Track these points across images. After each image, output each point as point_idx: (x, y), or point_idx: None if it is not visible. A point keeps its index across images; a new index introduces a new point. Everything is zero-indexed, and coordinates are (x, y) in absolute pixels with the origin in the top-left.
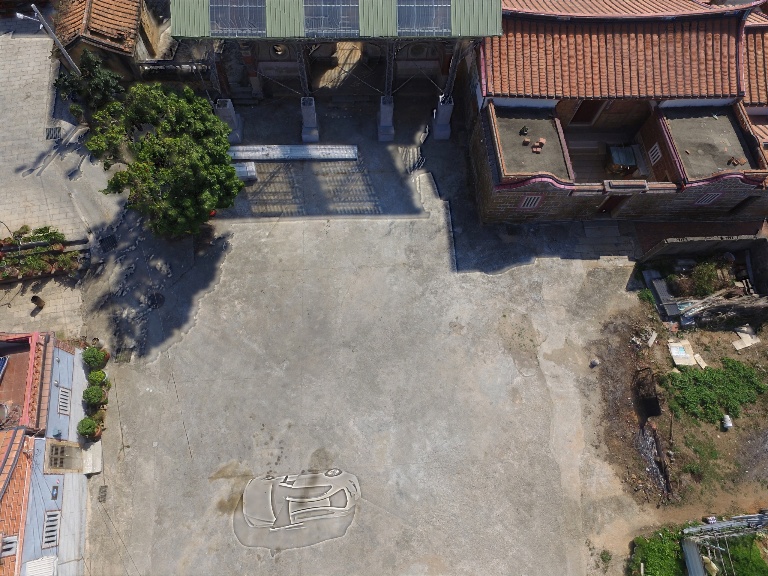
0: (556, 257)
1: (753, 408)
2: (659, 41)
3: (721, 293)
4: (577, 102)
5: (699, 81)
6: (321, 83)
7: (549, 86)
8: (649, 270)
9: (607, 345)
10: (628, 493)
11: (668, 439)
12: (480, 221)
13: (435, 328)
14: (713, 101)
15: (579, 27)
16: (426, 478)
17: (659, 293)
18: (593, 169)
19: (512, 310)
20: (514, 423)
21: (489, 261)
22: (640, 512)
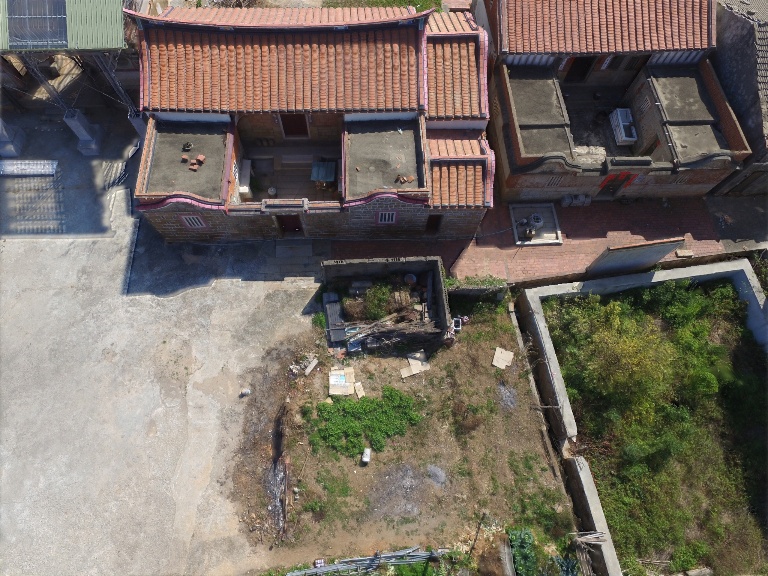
0: (237, 279)
1: (401, 441)
2: (335, 52)
3: (391, 318)
4: (272, 115)
5: (376, 94)
6: (36, 94)
7: (213, 100)
8: (329, 292)
9: (264, 373)
10: (243, 534)
11: (297, 475)
12: (165, 240)
13: (86, 355)
14: (397, 115)
15: (247, 37)
16: (29, 518)
17: (329, 317)
18: (304, 184)
19: (174, 336)
20: (141, 458)
21: (164, 283)
22: (250, 554)
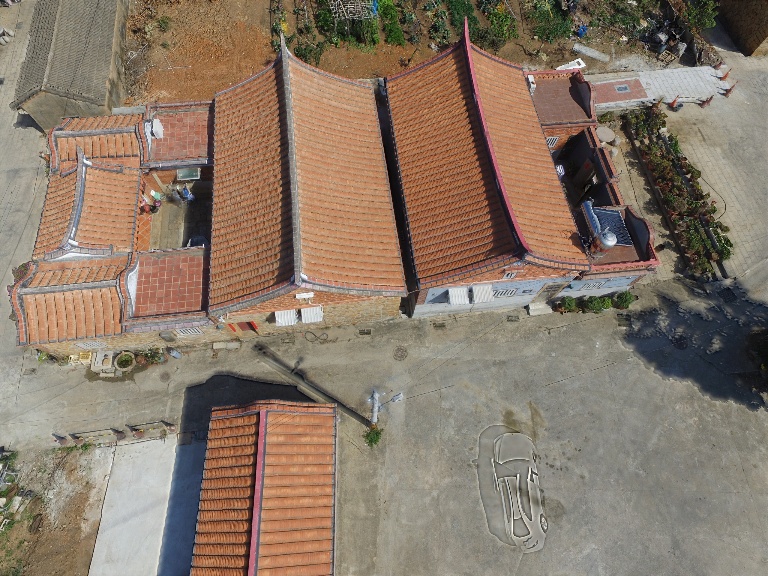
0: None
1: None
2: None
3: None
4: None
5: None
6: None
7: None
8: None
9: None
10: None
11: None
12: None
13: None
14: None
15: None
16: None
17: None
18: None
19: None
20: None
21: None
22: None
